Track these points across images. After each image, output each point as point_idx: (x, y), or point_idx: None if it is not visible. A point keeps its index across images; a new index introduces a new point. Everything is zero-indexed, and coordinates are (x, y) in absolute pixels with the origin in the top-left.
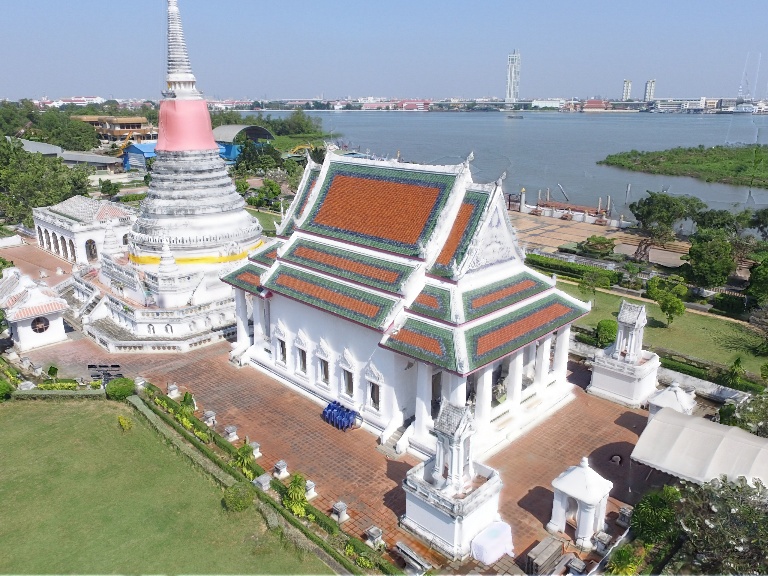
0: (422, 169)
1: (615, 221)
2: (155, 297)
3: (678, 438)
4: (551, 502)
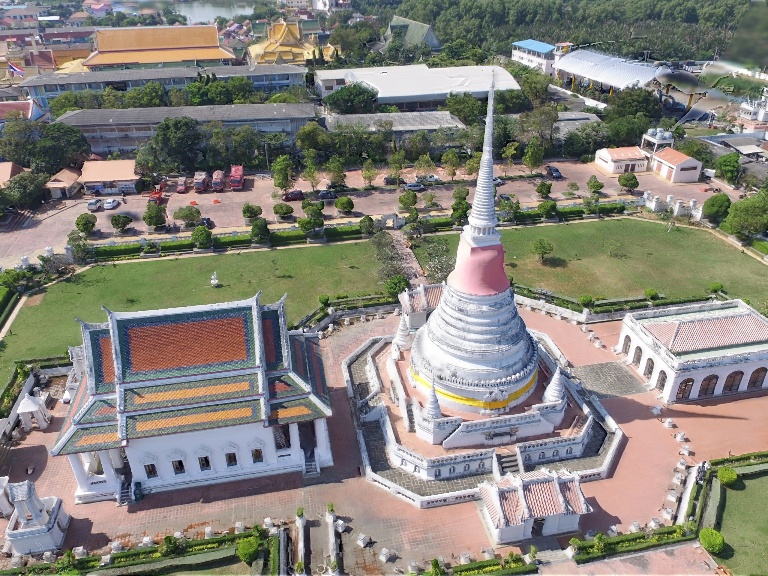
0: None
1: None
2: None
3: None
4: (56, 427)
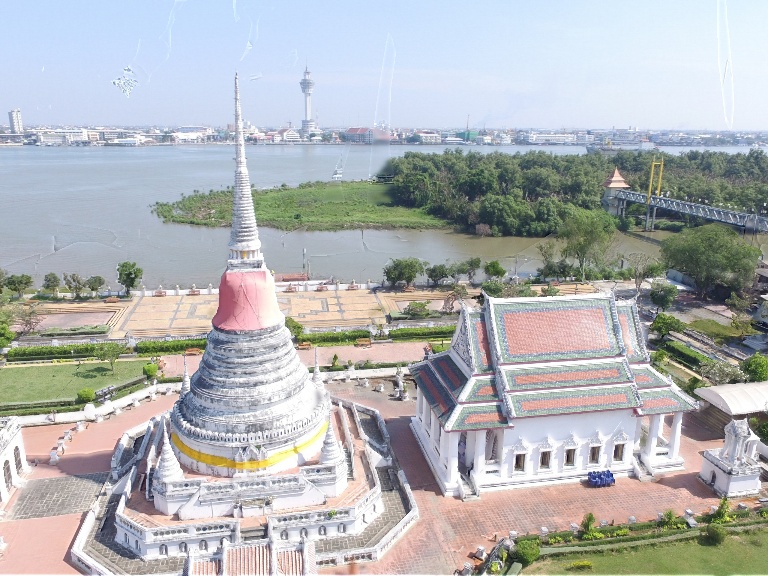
0: (582, 298)
1: (364, 285)
2: (326, 489)
3: (737, 397)
4: None
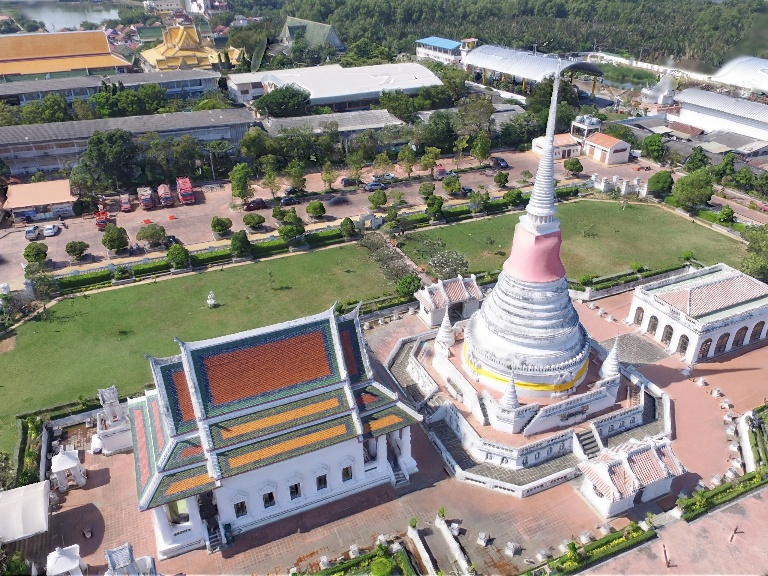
0: None
1: None
2: None
3: (25, 489)
4: (96, 481)
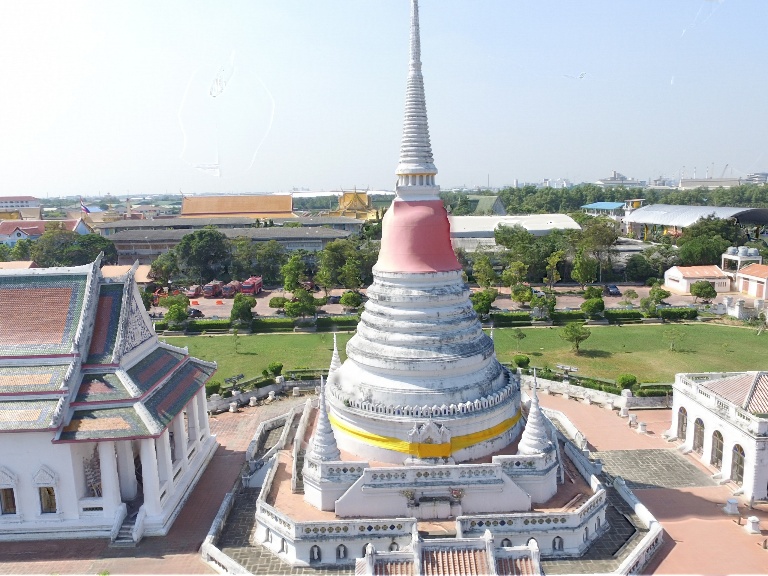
0: None
1: None
2: None
3: None
4: None
